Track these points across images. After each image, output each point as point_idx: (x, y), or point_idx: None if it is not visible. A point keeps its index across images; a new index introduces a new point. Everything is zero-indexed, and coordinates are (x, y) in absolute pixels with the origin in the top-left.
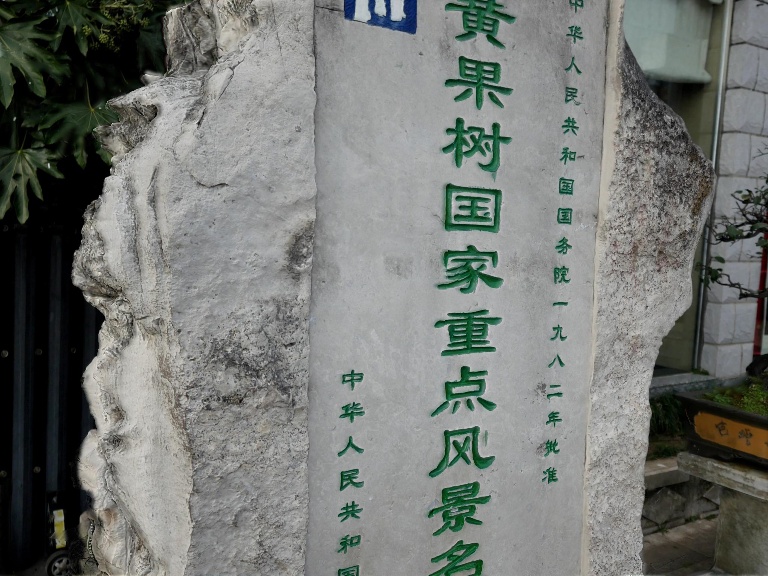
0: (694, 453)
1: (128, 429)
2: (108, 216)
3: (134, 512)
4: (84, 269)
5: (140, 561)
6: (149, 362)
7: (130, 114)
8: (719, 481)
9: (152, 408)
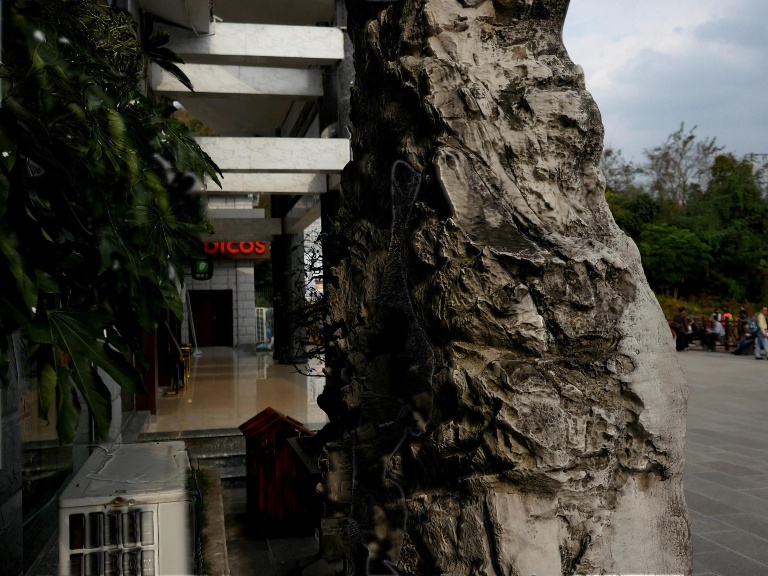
0: (335, 518)
1: None
2: (650, 377)
3: None
4: (568, 443)
5: None
6: (651, 510)
7: (582, 274)
8: None
9: (655, 553)
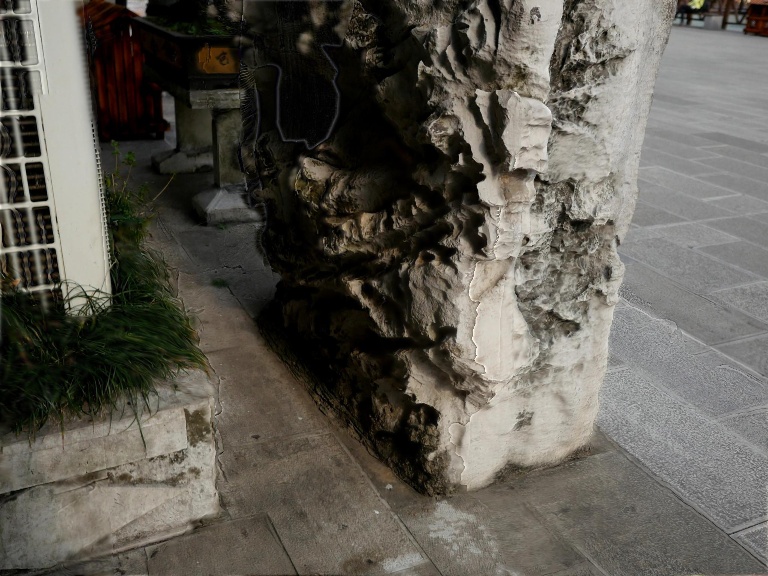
0: (204, 89)
1: (637, 40)
2: None
3: (606, 137)
4: None
5: (546, 210)
6: None
7: None
8: (234, 105)
9: None
